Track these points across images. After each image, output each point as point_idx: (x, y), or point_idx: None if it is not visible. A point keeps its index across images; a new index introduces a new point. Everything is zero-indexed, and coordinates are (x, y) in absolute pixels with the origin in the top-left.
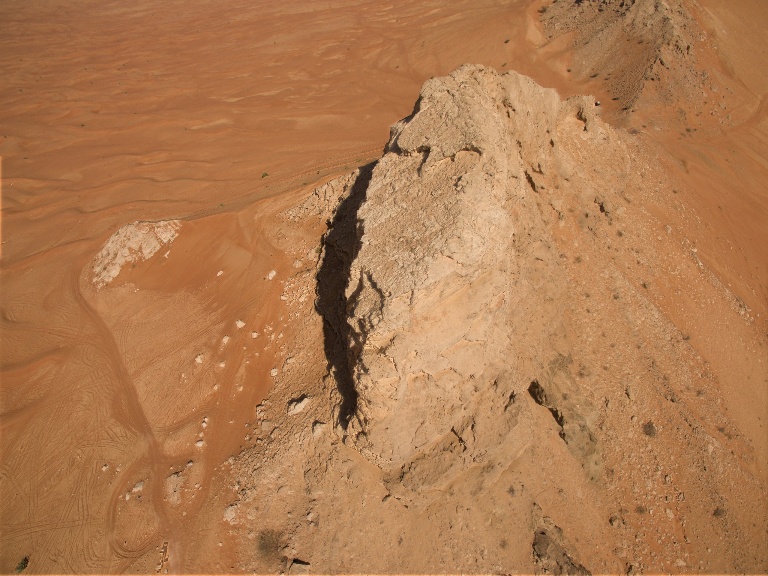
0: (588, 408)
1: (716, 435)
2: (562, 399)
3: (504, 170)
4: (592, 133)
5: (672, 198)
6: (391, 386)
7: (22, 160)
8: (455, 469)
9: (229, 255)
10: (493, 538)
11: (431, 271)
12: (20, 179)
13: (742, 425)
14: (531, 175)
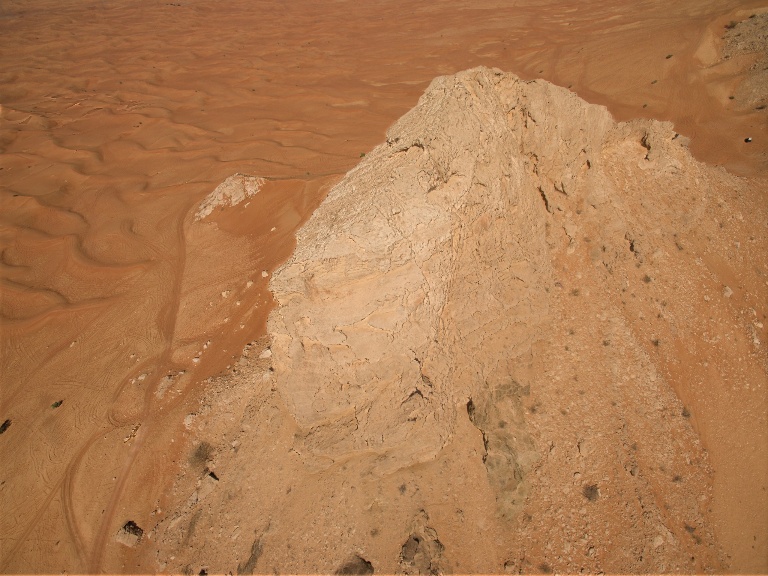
0: (526, 445)
1: (678, 531)
2: (497, 425)
3: (467, 174)
4: (657, 163)
5: (761, 260)
6: (286, 343)
7: (200, 112)
8: (346, 444)
9: (286, 215)
10: (367, 522)
11: (329, 247)
12: (190, 126)
13: (724, 535)
14: (547, 193)
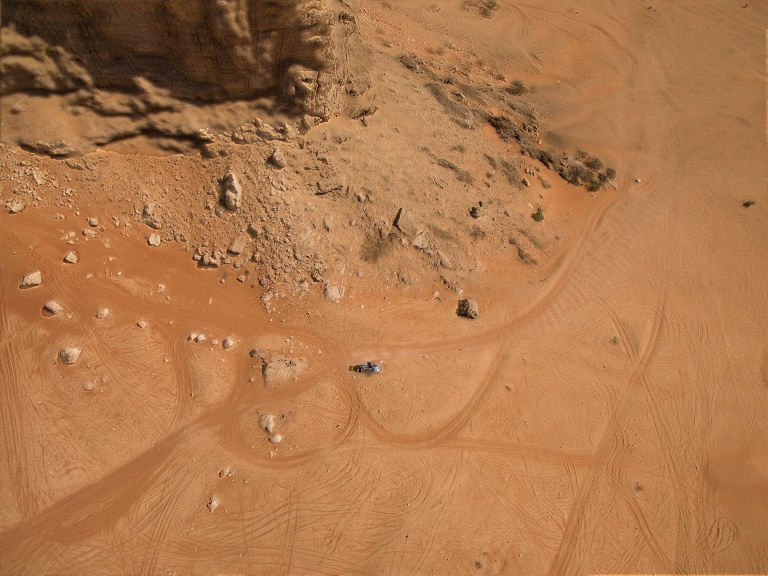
0: None
1: None
2: None
3: None
4: None
5: None
6: None
7: None
8: None
9: None
10: None
11: None
12: None
13: None
14: None
